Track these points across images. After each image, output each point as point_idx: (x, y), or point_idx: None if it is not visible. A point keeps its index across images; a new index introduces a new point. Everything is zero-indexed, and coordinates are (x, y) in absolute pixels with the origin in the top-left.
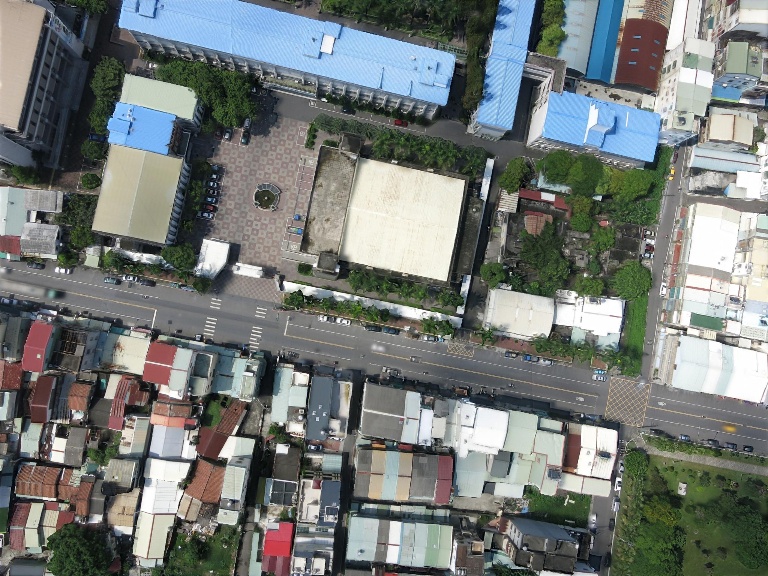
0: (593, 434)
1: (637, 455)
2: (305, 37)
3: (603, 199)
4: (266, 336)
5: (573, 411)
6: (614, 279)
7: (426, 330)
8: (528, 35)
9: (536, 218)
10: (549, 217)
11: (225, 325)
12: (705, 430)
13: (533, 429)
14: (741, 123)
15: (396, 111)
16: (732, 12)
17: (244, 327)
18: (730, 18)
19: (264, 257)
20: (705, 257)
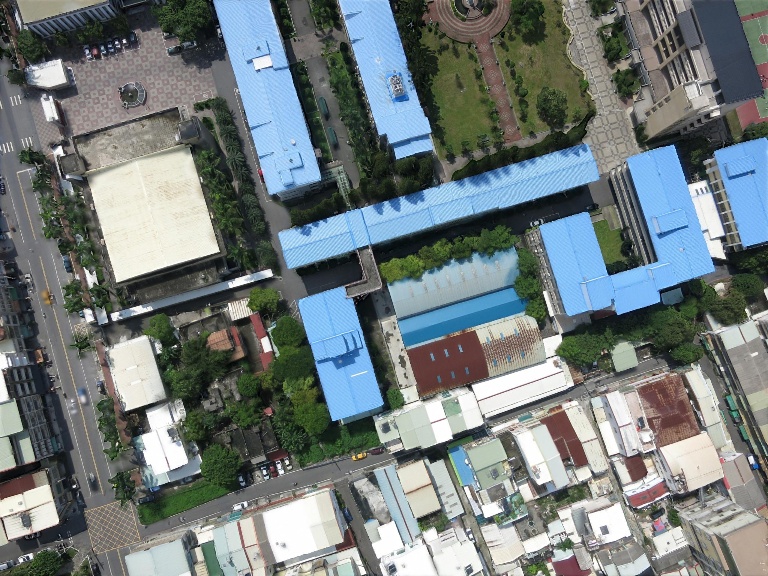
0: (43, 499)
1: (53, 559)
2: (258, 41)
3: None
4: (8, 157)
5: (77, 476)
6: (212, 446)
7: (64, 288)
8: (386, 238)
9: (225, 338)
10: (241, 353)
11: (0, 118)
12: None
13: (5, 432)
14: (429, 494)
15: None
16: (531, 427)
17: (7, 134)
18: (525, 428)
19: (78, 120)
20: (275, 526)
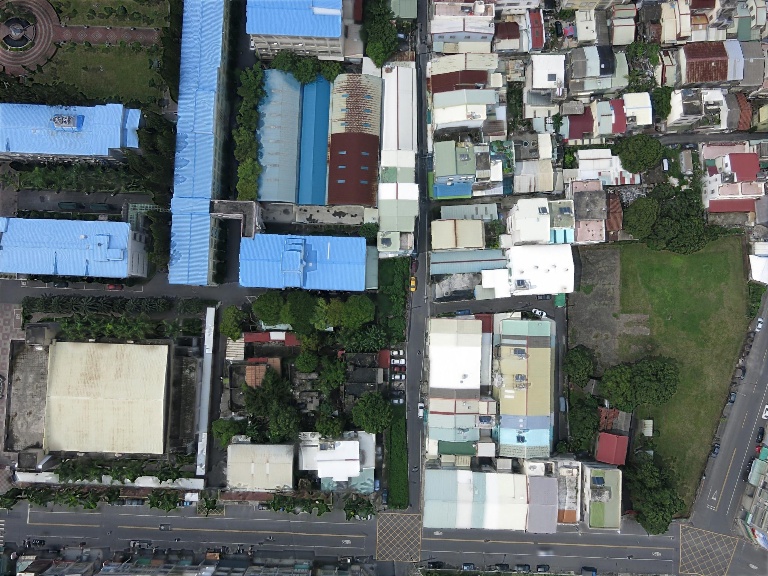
0: None
1: None
2: None
3: (335, 329)
4: (9, 528)
5: (340, 556)
6: (353, 416)
7: (151, 507)
8: (210, 183)
9: (254, 368)
10: (275, 360)
11: None
12: (491, 555)
13: None
14: (464, 226)
15: (100, 280)
16: None
17: None
18: None
19: None
20: (444, 378)
